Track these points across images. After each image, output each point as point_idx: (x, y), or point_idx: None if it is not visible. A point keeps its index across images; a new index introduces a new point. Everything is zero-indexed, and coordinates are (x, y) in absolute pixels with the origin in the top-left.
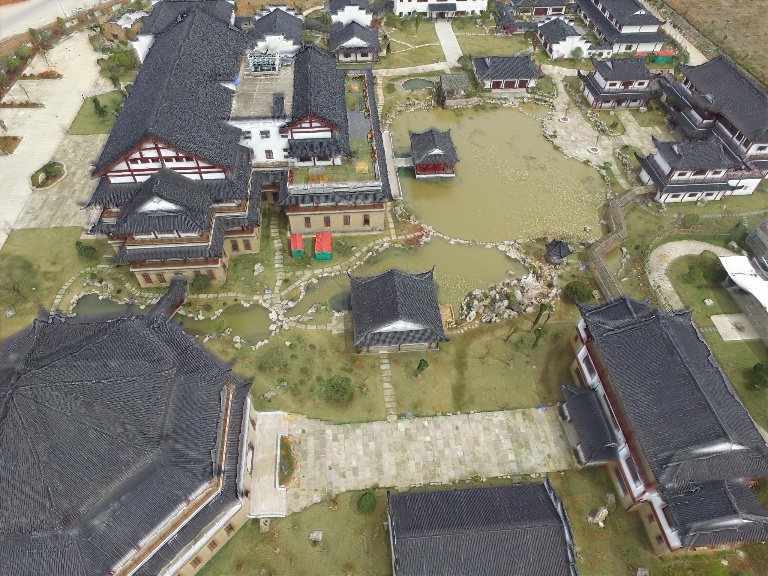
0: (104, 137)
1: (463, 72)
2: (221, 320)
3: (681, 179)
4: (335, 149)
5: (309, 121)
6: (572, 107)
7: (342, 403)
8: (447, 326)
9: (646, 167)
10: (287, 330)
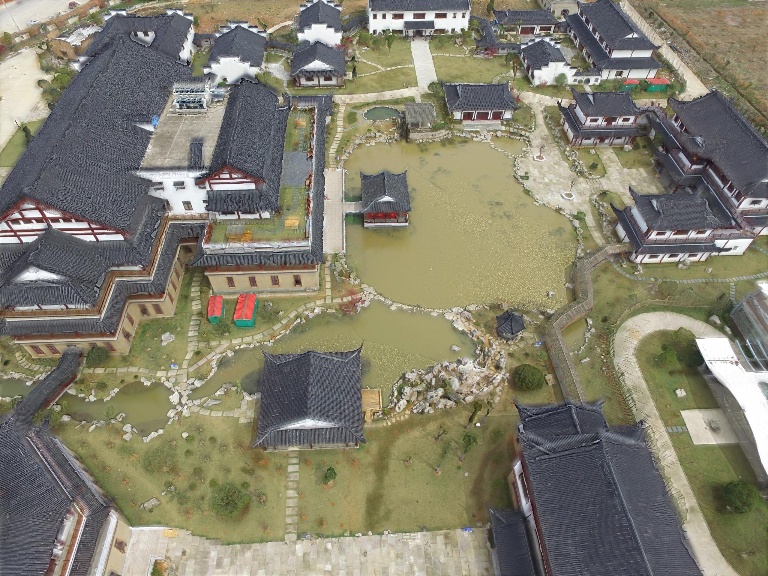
0: None
1: (434, 99)
2: (110, 405)
3: (660, 239)
4: (259, 202)
5: (228, 172)
6: (550, 143)
7: (235, 517)
8: (371, 417)
9: (622, 221)
10: (188, 417)
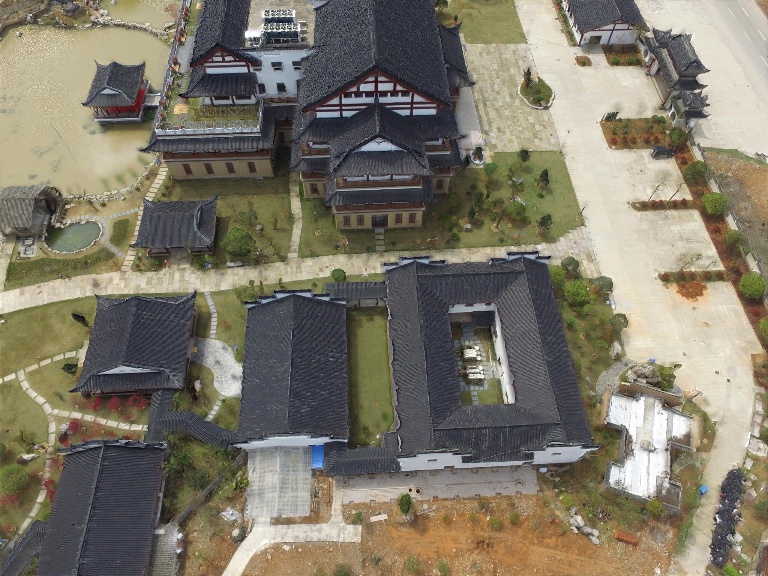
0: (512, 146)
1: None
2: None
3: None
4: None
5: None
6: None
7: None
8: None
9: None
10: None
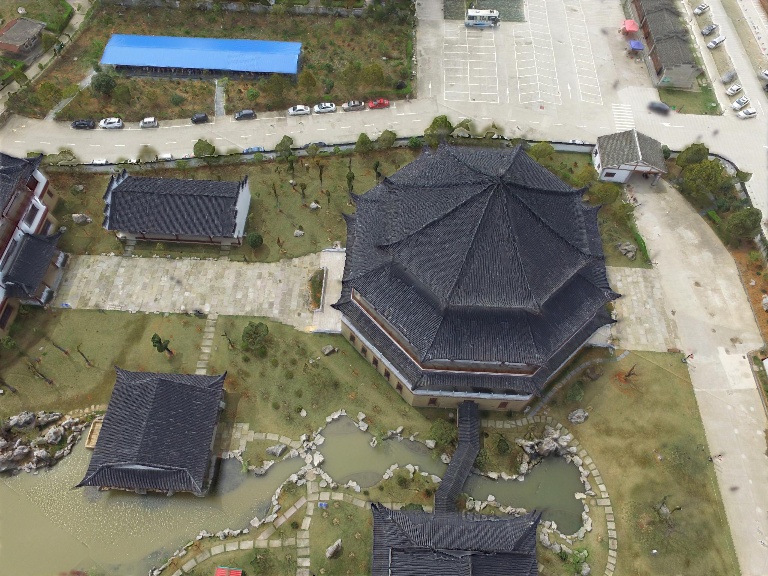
0: None
1: None
2: (380, 444)
3: None
4: None
5: None
6: None
7: None
8: None
9: None
10: None
